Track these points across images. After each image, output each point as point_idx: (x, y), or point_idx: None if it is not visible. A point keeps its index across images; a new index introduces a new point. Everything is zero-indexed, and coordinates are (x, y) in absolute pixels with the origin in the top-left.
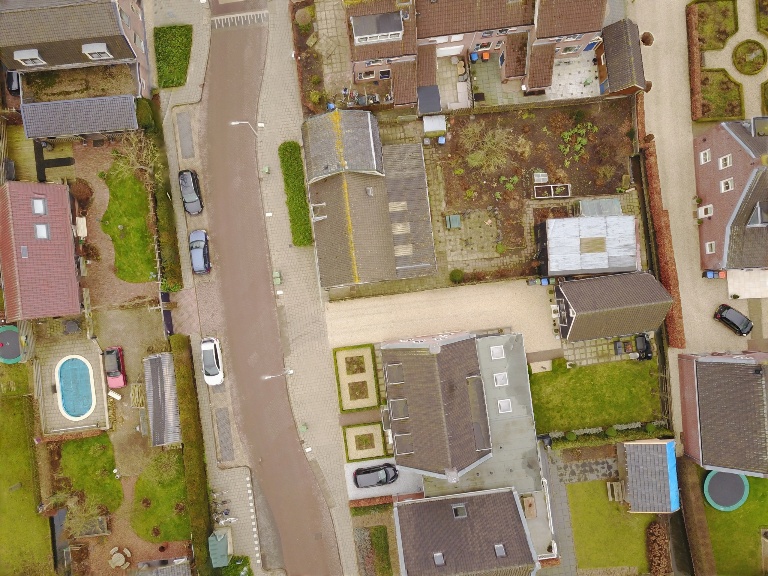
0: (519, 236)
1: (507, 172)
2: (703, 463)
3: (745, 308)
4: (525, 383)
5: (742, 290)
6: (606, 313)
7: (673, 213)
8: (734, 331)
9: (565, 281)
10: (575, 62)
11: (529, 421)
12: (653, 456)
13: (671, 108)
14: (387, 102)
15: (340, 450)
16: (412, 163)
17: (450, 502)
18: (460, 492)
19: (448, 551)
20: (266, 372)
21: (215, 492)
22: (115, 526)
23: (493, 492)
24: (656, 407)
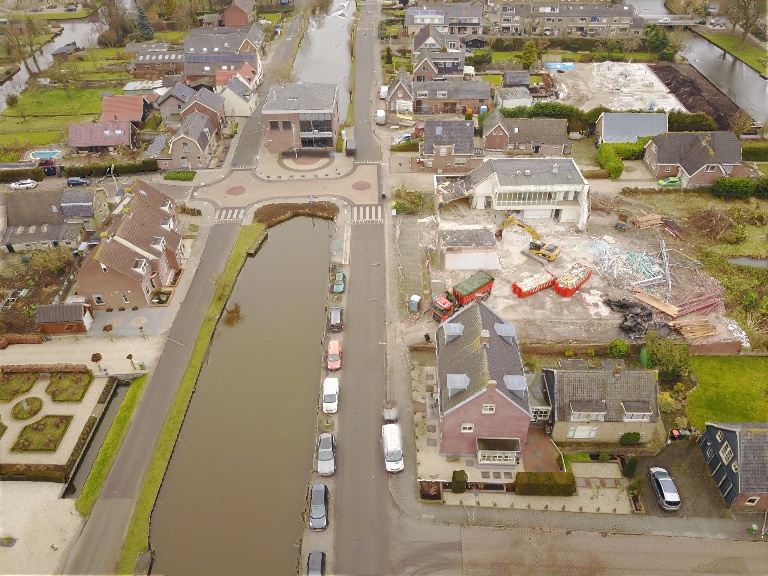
0: None
1: (40, 282)
2: None
3: None
4: None
5: None
6: None
7: None
8: None
9: None
10: None
11: None
12: None
13: None
14: None
15: None
16: None
17: None
18: None
19: None
20: (5, 201)
21: None
22: None
23: None
24: None
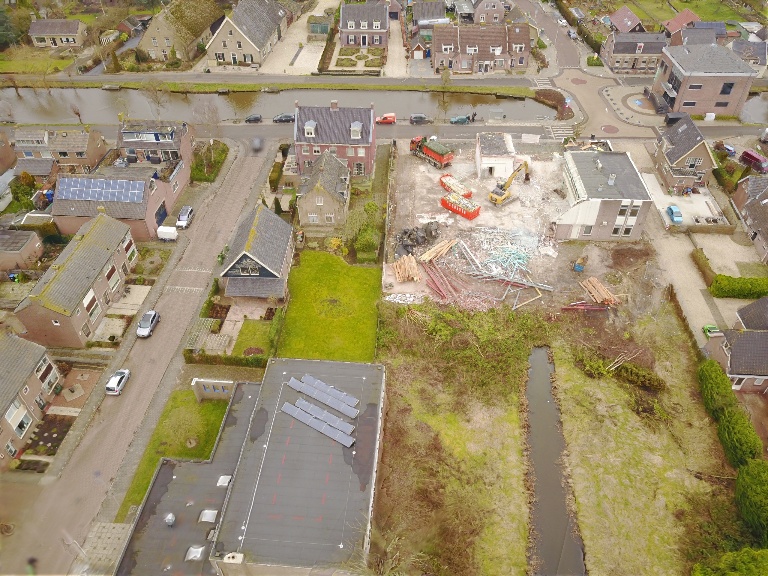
0: None
1: None
2: None
3: None
4: None
5: None
6: None
7: None
8: None
9: None
10: None
11: None
12: (416, 1)
13: None
14: None
15: None
16: None
17: None
18: None
19: None
20: None
21: (556, 7)
22: (587, 8)
23: None
24: None
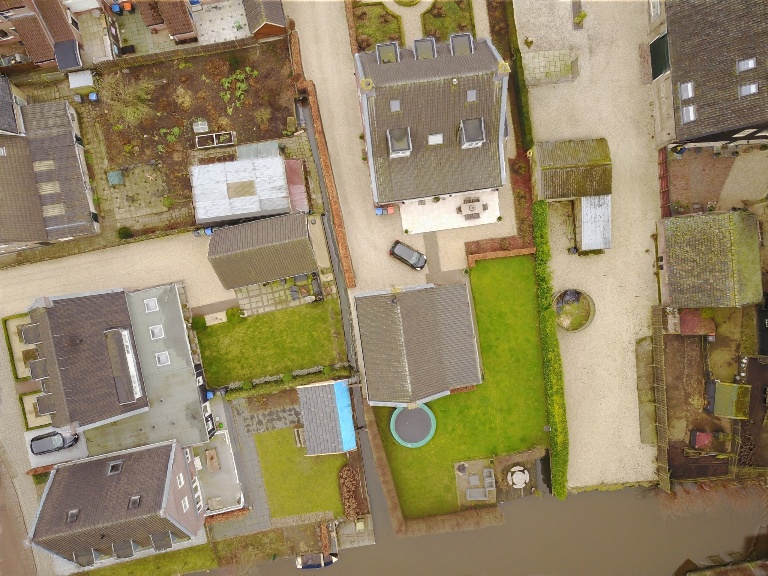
0: (186, 188)
1: (168, 124)
2: (369, 400)
3: (421, 242)
4: (182, 334)
5: (416, 224)
6: (240, 255)
7: (342, 152)
8: (409, 266)
9: (220, 228)
10: (226, 7)
11: (190, 372)
12: (323, 397)
13: (331, 46)
14: (27, 61)
15: (18, 419)
16: (58, 121)
17: (108, 460)
18: (123, 449)
19: (83, 507)
20: None
21: None
22: None
23: (154, 446)
24: (341, 349)
